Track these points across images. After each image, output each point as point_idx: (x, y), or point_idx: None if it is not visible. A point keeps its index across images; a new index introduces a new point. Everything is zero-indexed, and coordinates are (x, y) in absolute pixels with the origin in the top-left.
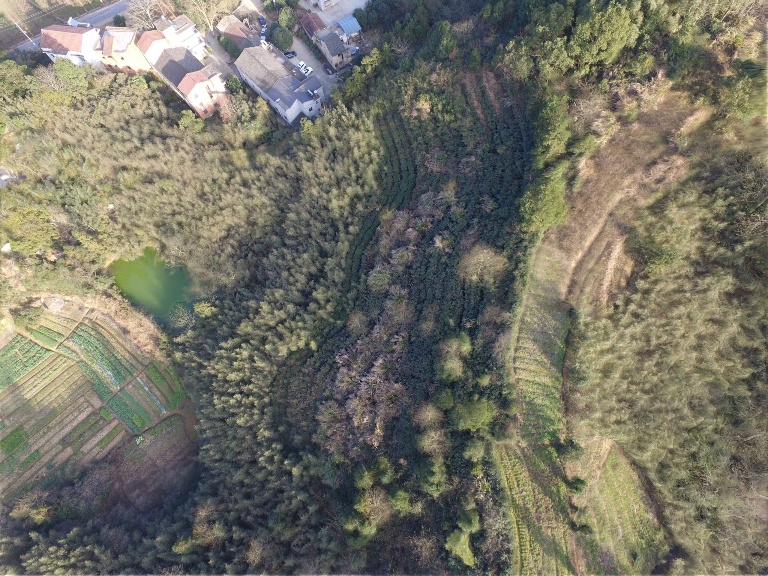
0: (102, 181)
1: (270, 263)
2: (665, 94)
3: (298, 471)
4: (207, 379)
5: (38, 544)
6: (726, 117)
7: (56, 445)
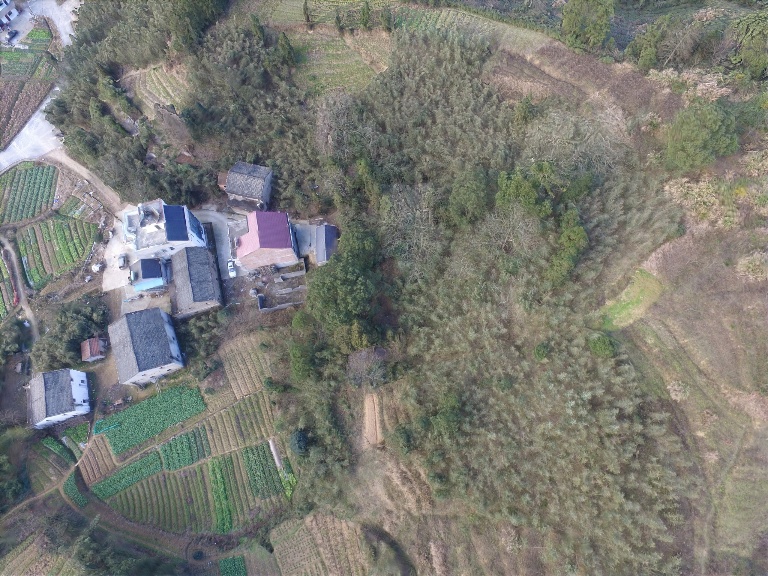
0: None
1: None
2: None
3: None
4: None
5: None
6: None
7: None
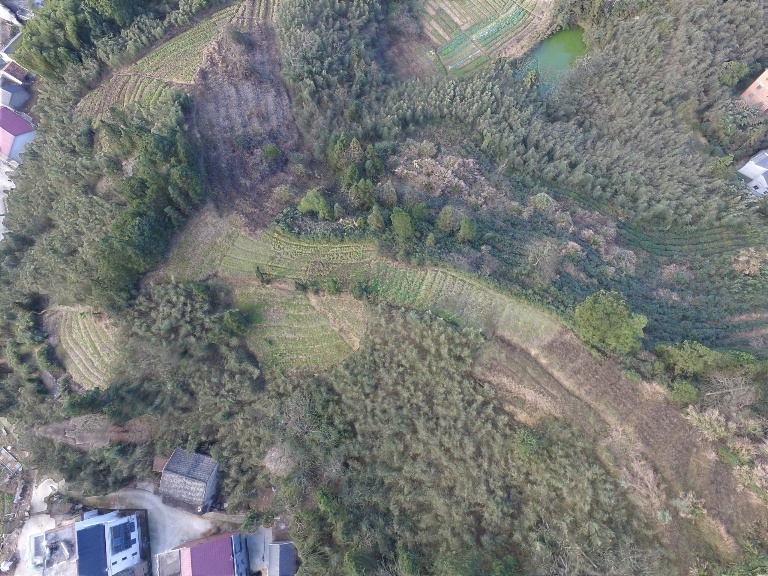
0: (663, 6)
1: (569, 128)
2: (763, 506)
3: (388, 120)
4: None
5: None
6: (724, 574)
7: (439, 6)
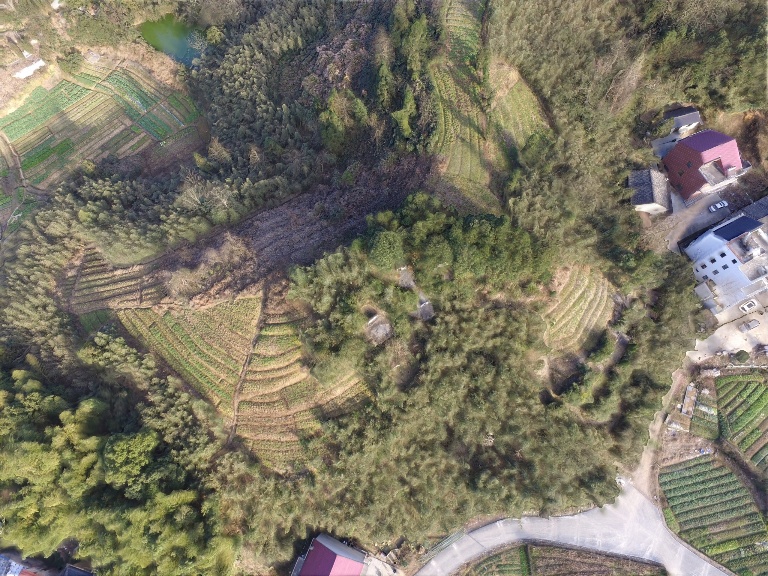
0: None
1: (267, 5)
2: None
3: (287, 109)
4: (217, 83)
5: (89, 181)
6: None
7: (97, 150)
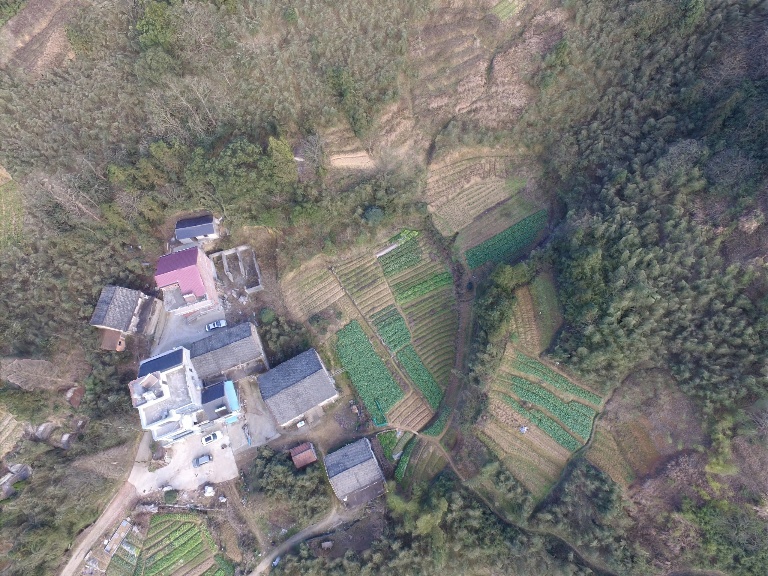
0: None
1: None
2: None
3: None
4: None
5: None
6: None
7: None
